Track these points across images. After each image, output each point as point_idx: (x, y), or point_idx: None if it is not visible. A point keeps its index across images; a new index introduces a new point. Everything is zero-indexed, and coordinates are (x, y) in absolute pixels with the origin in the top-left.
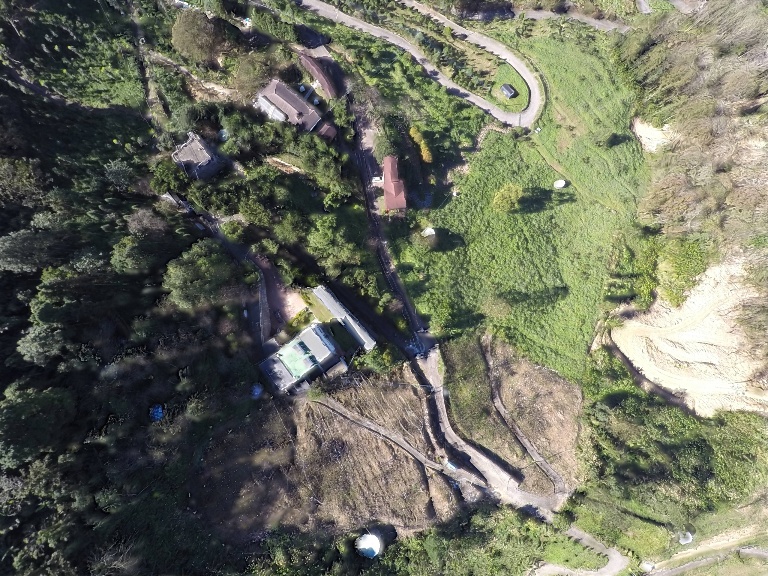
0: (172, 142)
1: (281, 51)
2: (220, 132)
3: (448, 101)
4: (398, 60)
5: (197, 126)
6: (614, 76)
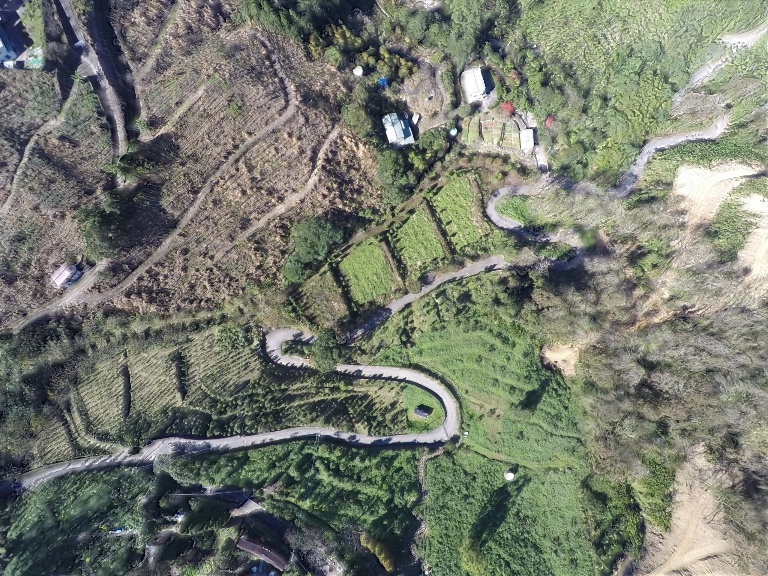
0: None
1: (220, 556)
2: None
3: (377, 471)
4: (317, 457)
5: None
6: (505, 334)
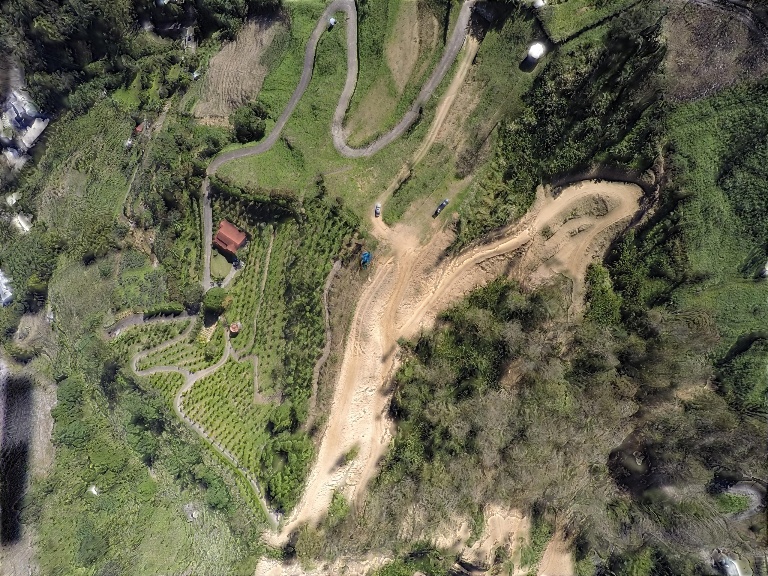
0: None
1: None
2: None
3: None
4: None
5: None
6: None
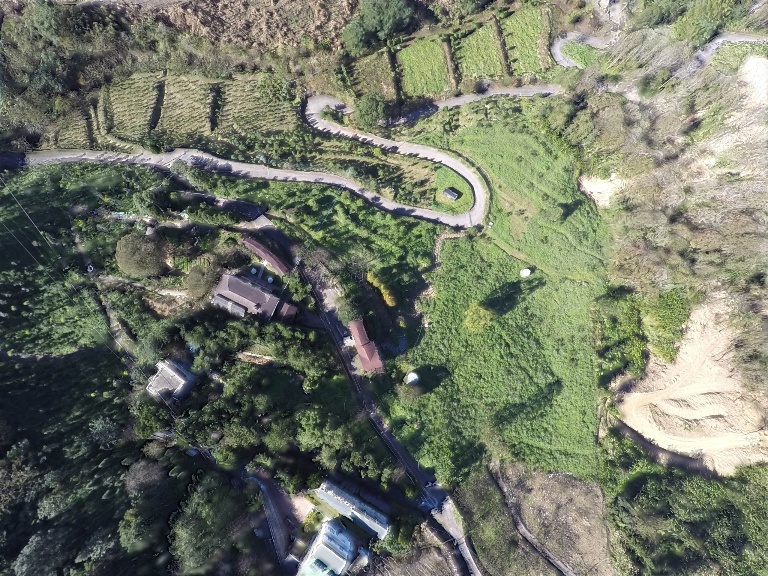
0: (143, 377)
1: (224, 244)
2: (186, 345)
3: (396, 228)
4: (338, 201)
5: (163, 351)
6: (550, 146)
